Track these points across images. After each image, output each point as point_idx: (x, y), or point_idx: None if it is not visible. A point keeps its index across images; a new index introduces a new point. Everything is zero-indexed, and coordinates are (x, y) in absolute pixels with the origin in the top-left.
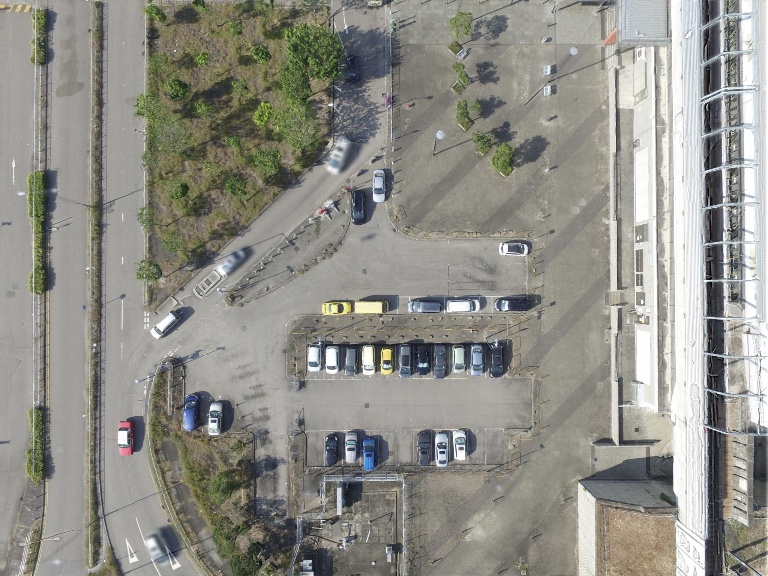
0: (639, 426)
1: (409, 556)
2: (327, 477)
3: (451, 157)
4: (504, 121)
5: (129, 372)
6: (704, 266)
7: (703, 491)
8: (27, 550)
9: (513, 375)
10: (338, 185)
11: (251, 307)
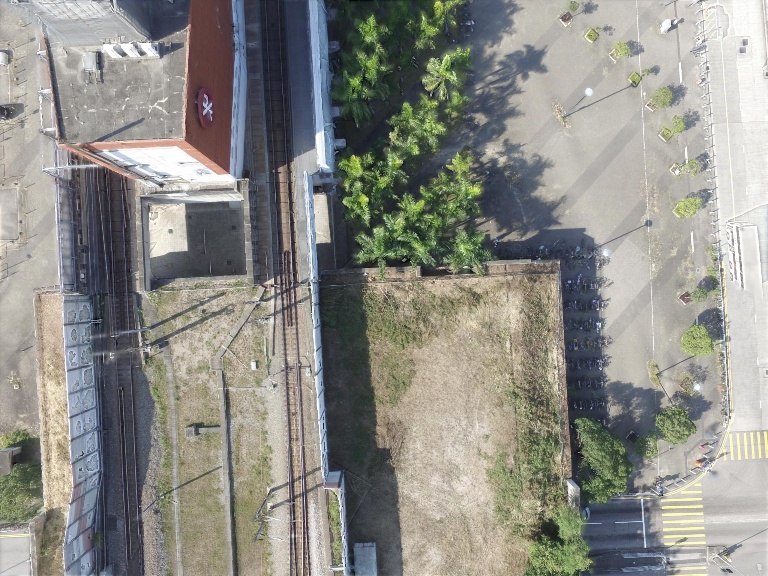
0: None
1: None
2: None
3: None
4: None
5: None
6: None
7: None
8: None
9: None
10: None
11: None
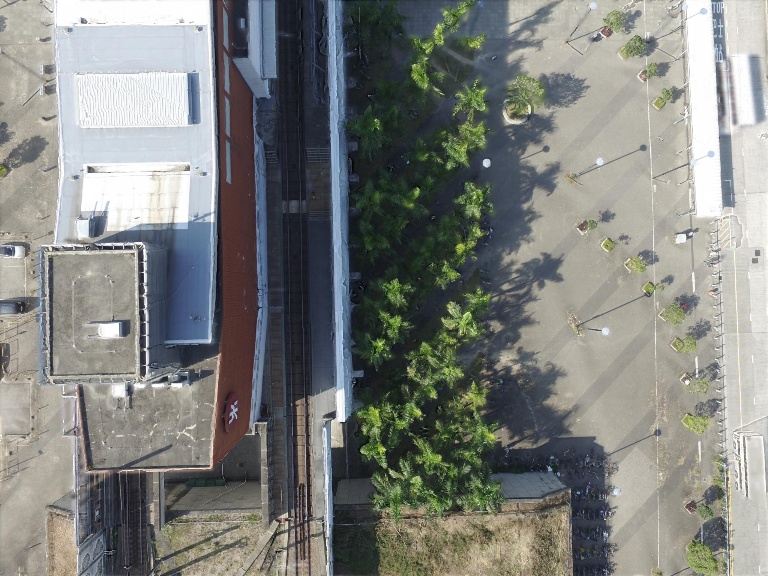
0: None
1: None
2: None
3: None
4: (1, 122)
5: None
6: None
7: None
8: None
9: (10, 380)
10: None
11: None
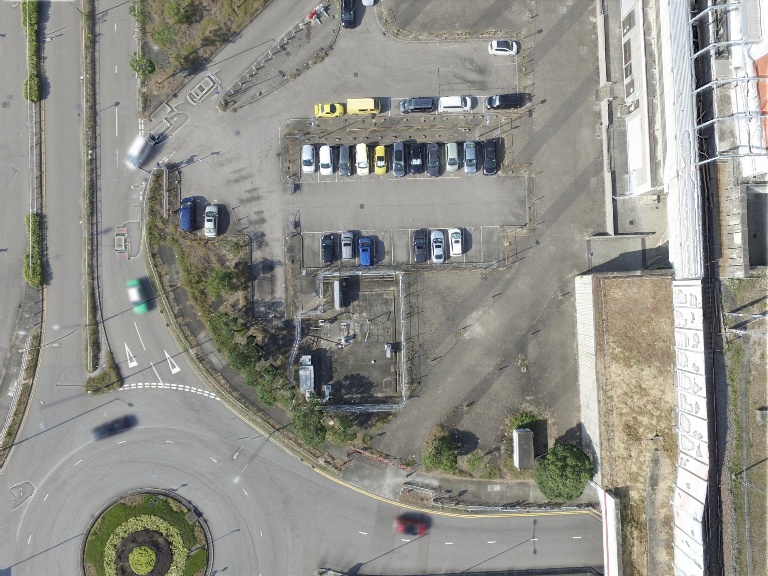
0: (634, 218)
1: (408, 355)
2: (324, 277)
3: None
4: None
5: (125, 178)
6: (689, 9)
7: (697, 230)
8: (26, 357)
9: (506, 172)
10: None
11: (244, 112)
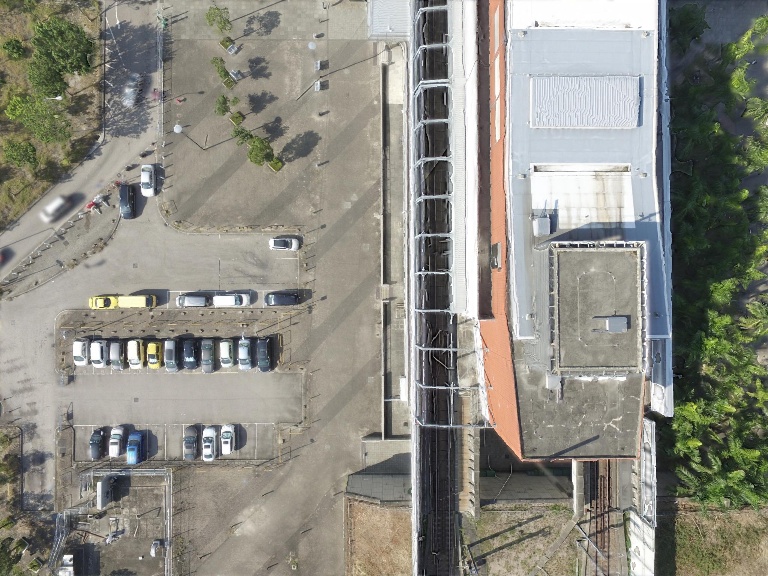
0: (408, 420)
1: (178, 551)
2: (95, 472)
3: (222, 152)
4: (276, 116)
5: None
6: (417, 259)
7: (415, 483)
8: None
9: (283, 369)
10: (109, 180)
11: (20, 301)
